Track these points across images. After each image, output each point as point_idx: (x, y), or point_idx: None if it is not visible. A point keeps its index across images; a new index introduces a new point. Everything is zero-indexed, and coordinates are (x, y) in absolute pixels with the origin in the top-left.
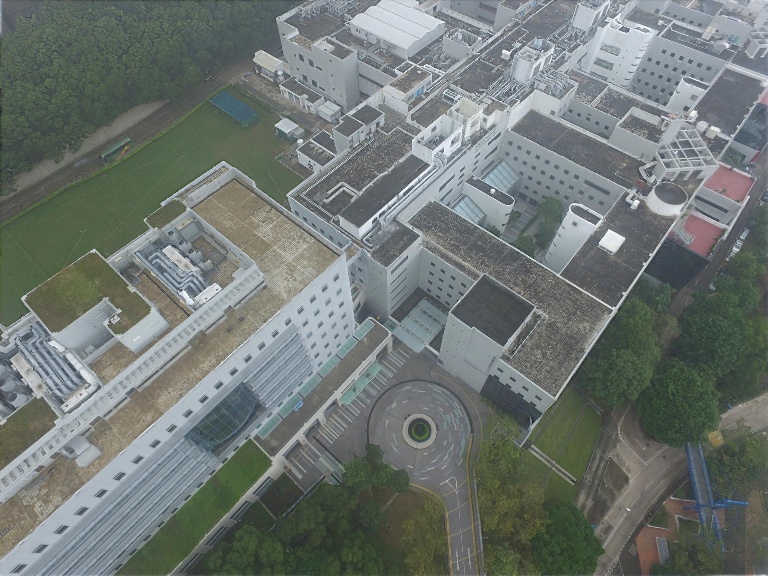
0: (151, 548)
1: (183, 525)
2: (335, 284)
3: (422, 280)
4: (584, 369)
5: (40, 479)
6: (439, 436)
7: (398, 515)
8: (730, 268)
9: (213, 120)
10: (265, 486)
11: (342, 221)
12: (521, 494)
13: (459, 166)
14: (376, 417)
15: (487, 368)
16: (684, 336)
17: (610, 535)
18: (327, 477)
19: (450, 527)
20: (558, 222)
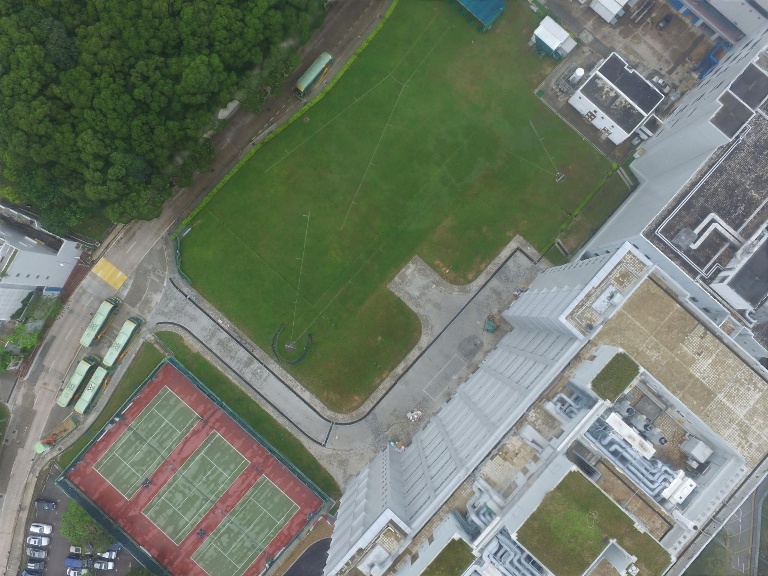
0: None
1: None
2: None
3: None
4: None
5: None
6: None
7: None
8: None
9: (434, 11)
10: None
11: (725, 289)
12: None
13: None
14: None
15: None
16: None
17: None
18: None
19: None
20: None
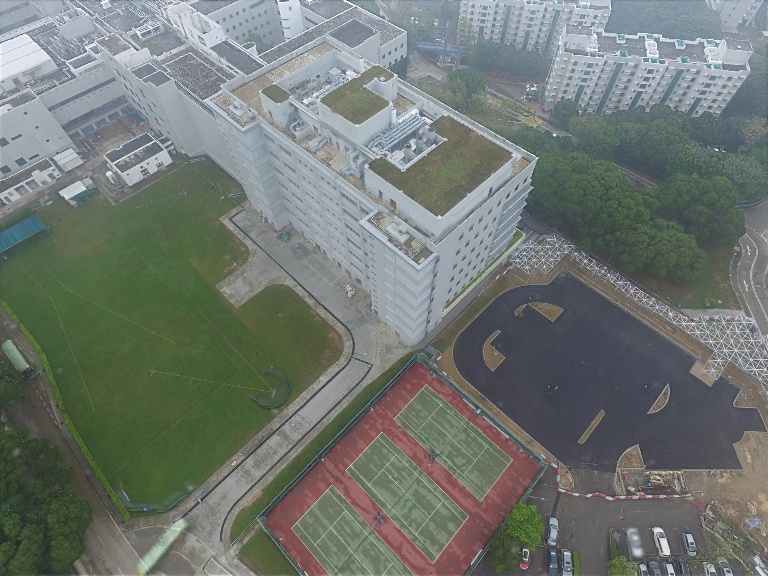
0: None
1: None
2: None
3: None
4: None
5: None
6: None
7: None
8: None
9: (15, 266)
10: None
11: None
12: None
13: None
14: None
15: None
16: None
17: None
18: None
19: None
20: None
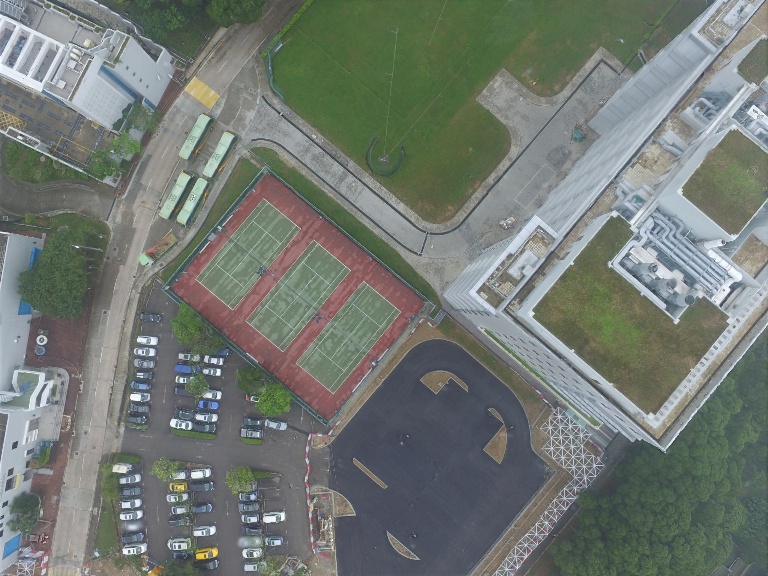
0: None
1: None
2: None
3: None
4: None
5: None
6: None
7: None
8: None
9: None
10: None
11: None
12: None
13: None
14: None
15: None
16: None
17: None
18: None
19: None
20: None
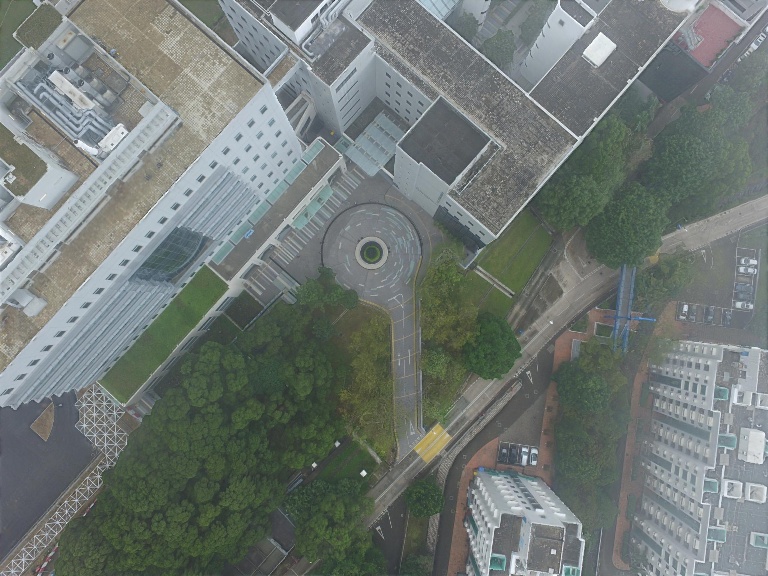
0: (132, 355)
1: (156, 338)
2: (264, 116)
3: (379, 90)
4: (541, 194)
5: None
6: (390, 258)
7: (349, 325)
8: (737, 73)
9: None
10: (227, 303)
11: (274, 19)
12: (458, 311)
13: None
14: (330, 239)
15: (437, 200)
16: (654, 159)
17: (534, 338)
18: (285, 294)
19: (395, 334)
20: (550, 9)
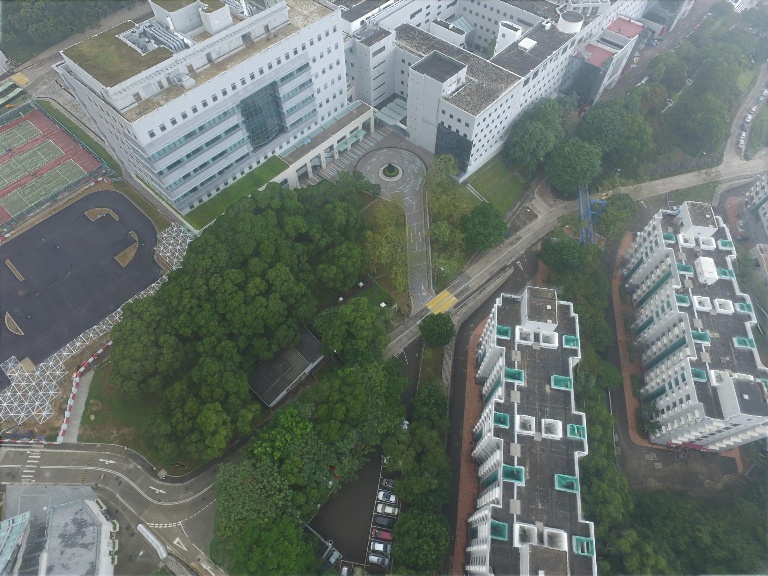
0: (211, 202)
1: (232, 193)
2: (334, 36)
3: (397, 83)
4: (508, 139)
5: (162, 93)
6: (404, 176)
7: None
8: None
9: None
10: None
11: None
12: None
13: (425, 2)
14: (361, 165)
15: (436, 117)
16: (582, 124)
17: (520, 241)
18: None
19: (408, 221)
20: None
